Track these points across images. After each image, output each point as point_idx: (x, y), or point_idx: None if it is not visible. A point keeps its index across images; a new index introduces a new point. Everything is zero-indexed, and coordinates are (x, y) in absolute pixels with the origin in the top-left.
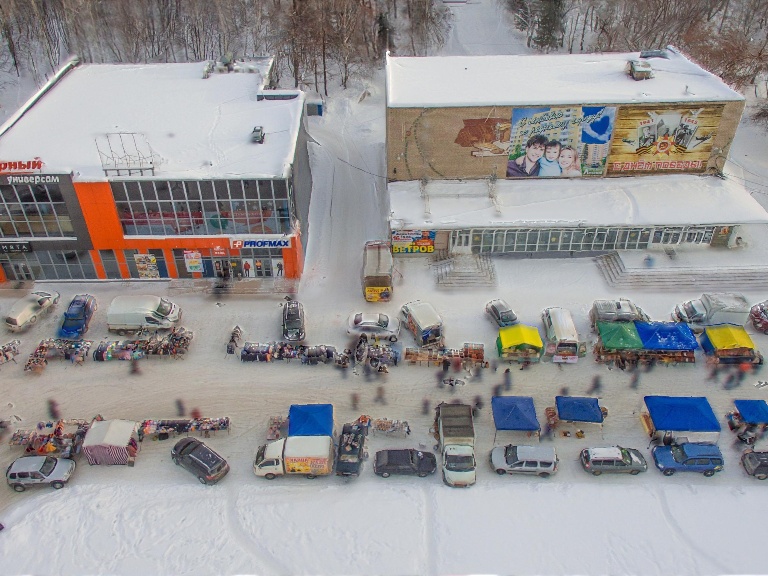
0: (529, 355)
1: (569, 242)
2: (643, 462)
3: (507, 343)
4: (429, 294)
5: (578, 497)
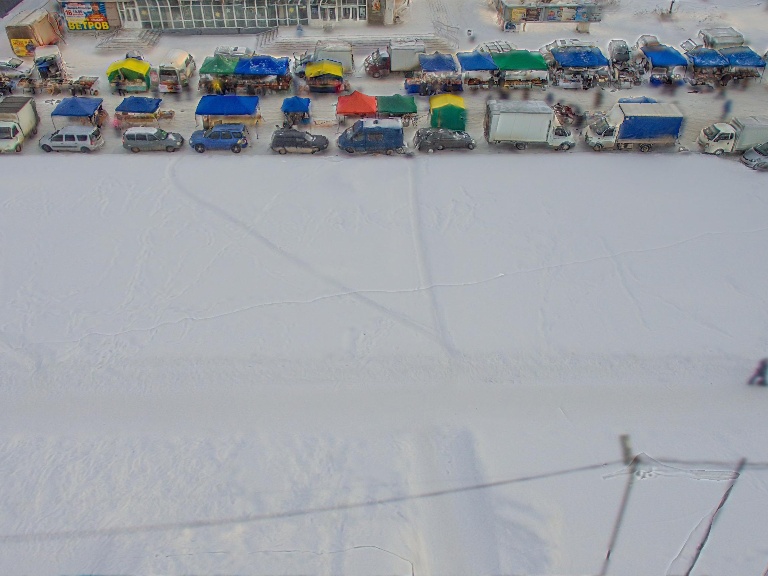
0: (135, 84)
1: (233, 18)
2: (178, 140)
3: (109, 69)
4: (83, 54)
5: (99, 159)
